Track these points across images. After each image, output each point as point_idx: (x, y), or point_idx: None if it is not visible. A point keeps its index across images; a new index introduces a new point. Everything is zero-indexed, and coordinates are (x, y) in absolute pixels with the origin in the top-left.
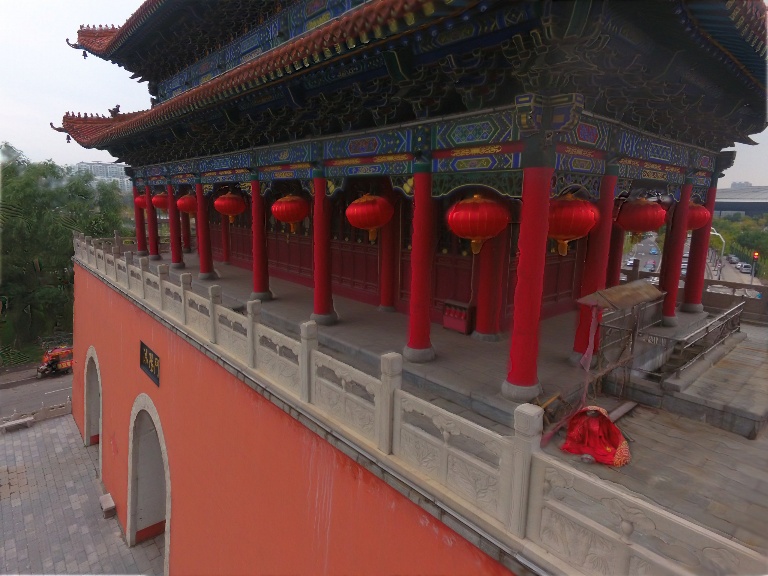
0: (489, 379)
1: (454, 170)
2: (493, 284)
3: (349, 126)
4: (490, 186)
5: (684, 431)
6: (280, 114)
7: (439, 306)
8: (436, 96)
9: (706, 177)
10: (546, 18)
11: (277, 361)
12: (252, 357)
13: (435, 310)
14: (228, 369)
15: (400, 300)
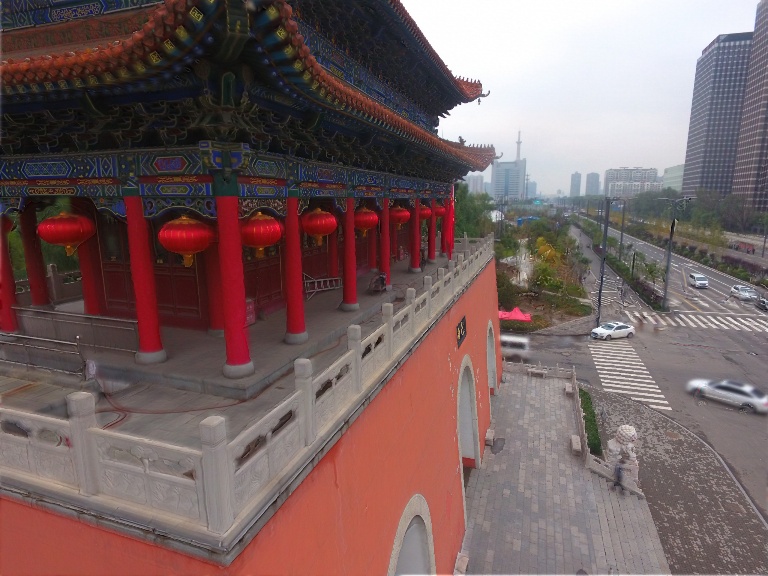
0: None
1: None
2: None
3: None
4: None
5: None
6: None
7: None
8: None
9: (193, 183)
10: None
11: None
12: None
13: None
14: None
15: None
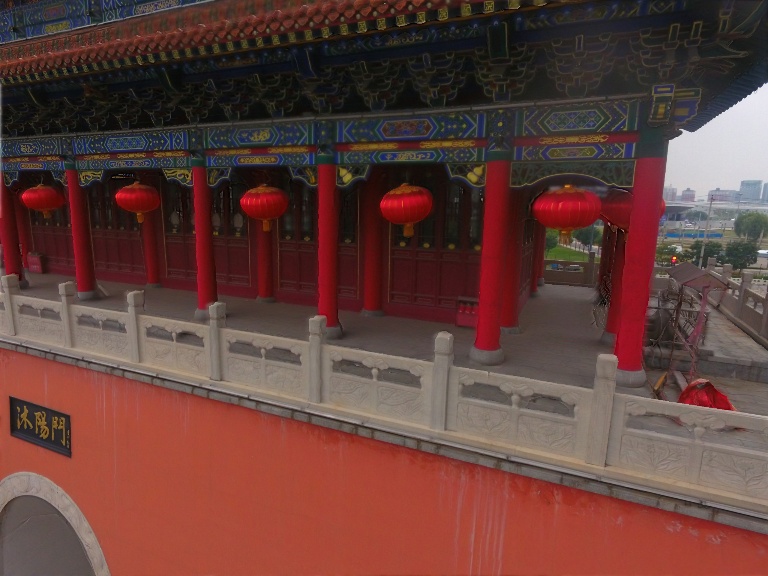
0: (576, 370)
1: (546, 159)
2: (516, 277)
3: (383, 105)
4: (592, 176)
5: (735, 388)
6: (270, 83)
7: (444, 304)
8: (521, 79)
9: None
10: (728, 10)
11: (376, 388)
12: (318, 389)
13: (439, 309)
14: (269, 410)
15: (390, 302)
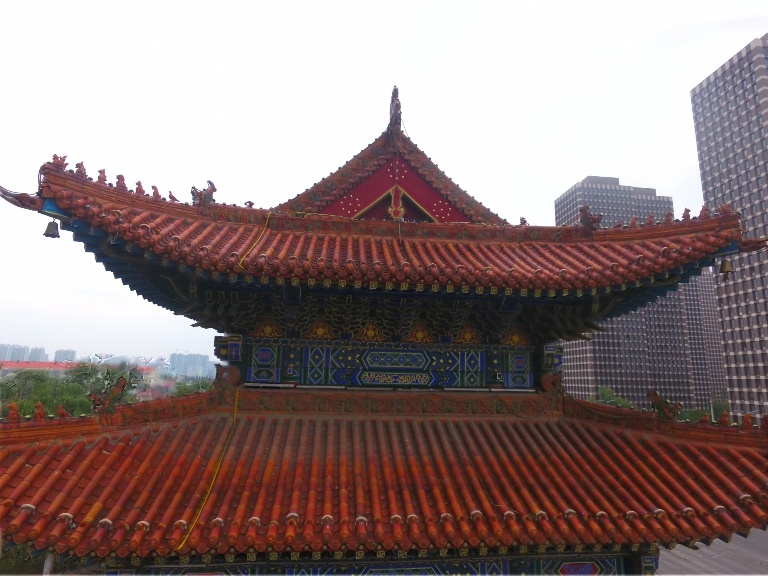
0: None
1: None
2: None
3: None
4: None
5: None
6: None
7: None
8: None
9: None
10: None
11: None
12: None
13: None
14: None
15: None
